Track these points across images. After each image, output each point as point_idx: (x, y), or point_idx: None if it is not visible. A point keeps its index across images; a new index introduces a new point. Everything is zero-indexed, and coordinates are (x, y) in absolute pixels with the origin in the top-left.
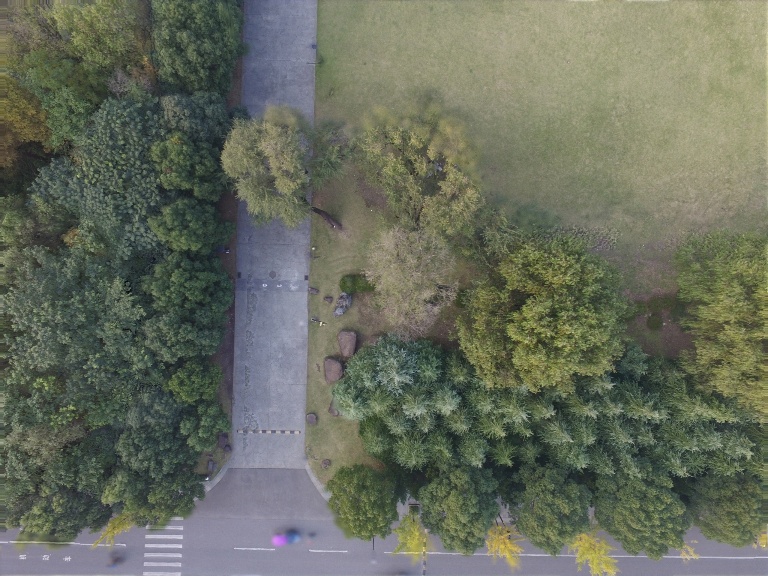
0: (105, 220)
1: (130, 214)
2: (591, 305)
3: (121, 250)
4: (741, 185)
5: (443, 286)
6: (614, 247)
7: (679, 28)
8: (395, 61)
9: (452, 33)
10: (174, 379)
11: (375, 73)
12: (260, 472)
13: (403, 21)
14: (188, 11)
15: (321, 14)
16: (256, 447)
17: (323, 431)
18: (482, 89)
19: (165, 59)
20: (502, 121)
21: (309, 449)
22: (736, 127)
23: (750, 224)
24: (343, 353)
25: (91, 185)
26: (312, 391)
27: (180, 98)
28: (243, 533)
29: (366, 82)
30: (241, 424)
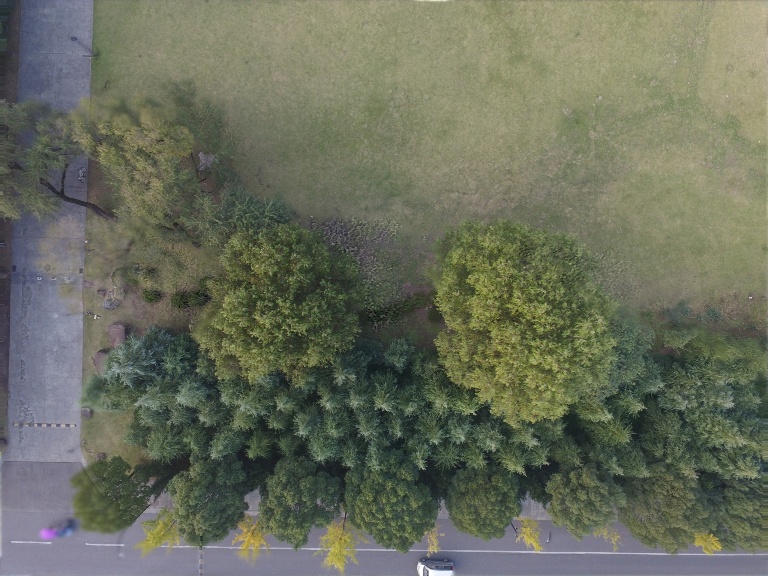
0: None
1: None
2: (370, 298)
3: None
4: (522, 176)
5: (219, 279)
6: (394, 239)
7: (458, 18)
8: (170, 53)
9: (227, 24)
10: None
11: (150, 65)
12: (36, 465)
13: (178, 13)
14: None
15: (97, 7)
16: (32, 440)
17: (98, 424)
18: (258, 81)
19: None
20: (278, 113)
21: (84, 442)
22: (516, 117)
23: (533, 216)
24: (113, 346)
25: None
26: (87, 384)
27: None
28: (20, 526)
29: (141, 74)
30: (17, 417)
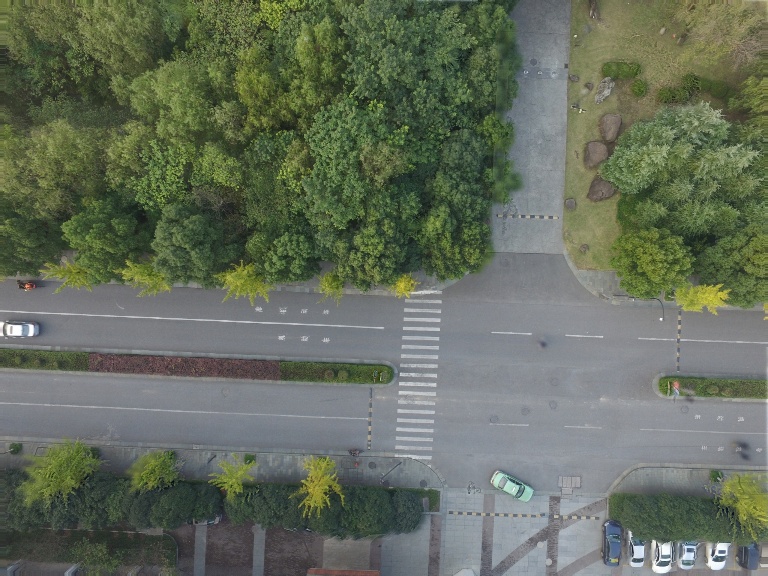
0: None
1: None
2: None
3: None
4: None
5: (698, 78)
6: None
7: None
8: None
9: None
10: (488, 119)
11: None
12: (518, 256)
13: None
14: None
15: None
16: (515, 232)
17: (581, 217)
18: None
19: None
20: None
21: (568, 234)
22: None
23: None
24: (607, 136)
25: None
26: (571, 177)
27: None
28: (500, 317)
29: None
30: (501, 208)
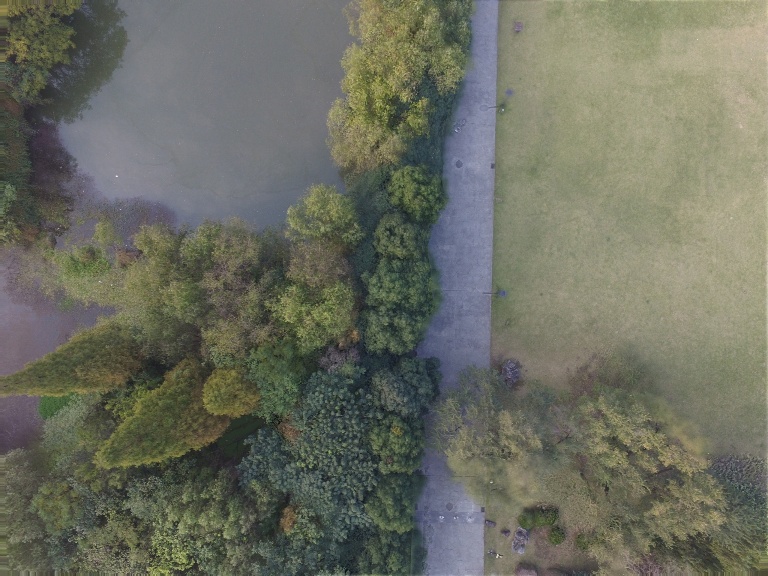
0: (322, 504)
1: (344, 495)
2: (765, 534)
3: (336, 533)
4: None
5: (619, 517)
6: None
7: None
8: (572, 292)
9: (629, 264)
10: None
11: (552, 304)
12: None
13: (580, 252)
14: (404, 293)
15: (497, 243)
16: None
17: None
18: (659, 320)
19: (379, 340)
20: (678, 352)
21: None
22: None
23: None
24: None
25: (308, 470)
26: None
27: (399, 384)
28: None
29: (543, 313)
30: None
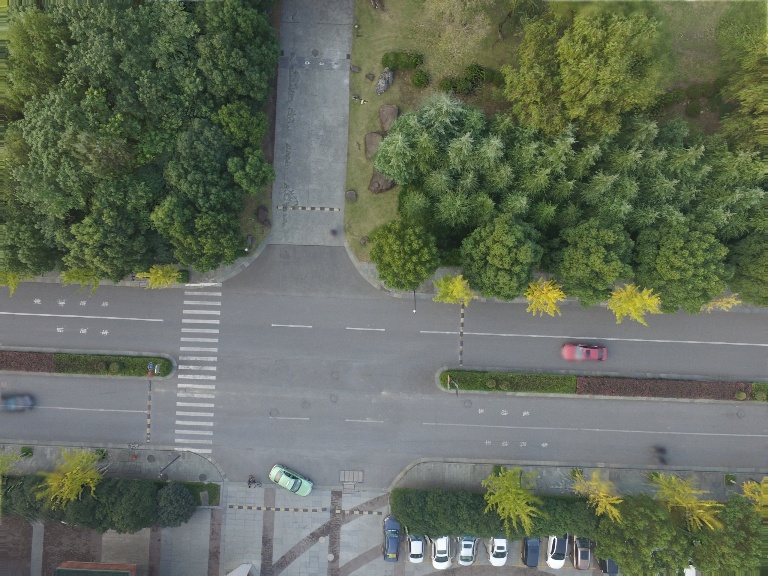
0: None
1: None
2: (630, 92)
3: None
4: None
5: (484, 68)
6: (653, 35)
7: None
8: None
9: None
10: (224, 108)
11: None
12: (299, 249)
13: None
14: None
15: None
16: (295, 223)
17: (362, 209)
18: None
19: None
20: None
21: (348, 226)
22: None
23: None
24: (384, 127)
25: None
26: (352, 169)
27: None
28: (281, 310)
29: None
30: (281, 200)
